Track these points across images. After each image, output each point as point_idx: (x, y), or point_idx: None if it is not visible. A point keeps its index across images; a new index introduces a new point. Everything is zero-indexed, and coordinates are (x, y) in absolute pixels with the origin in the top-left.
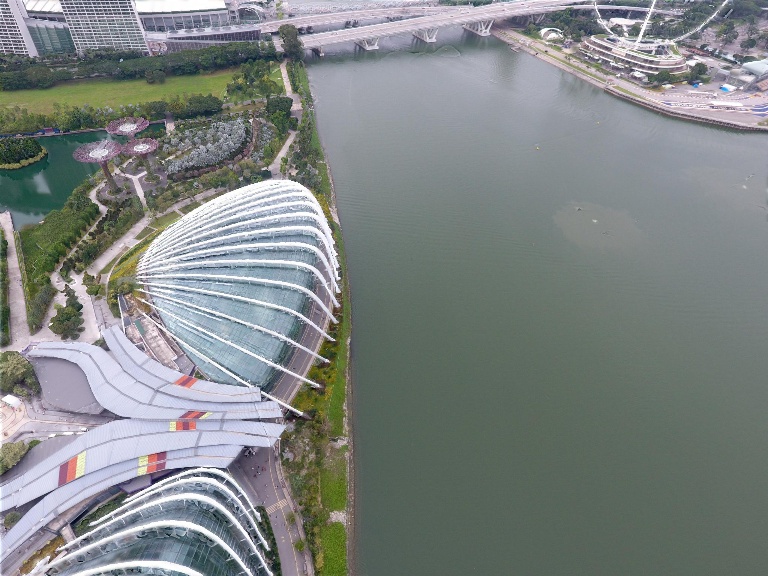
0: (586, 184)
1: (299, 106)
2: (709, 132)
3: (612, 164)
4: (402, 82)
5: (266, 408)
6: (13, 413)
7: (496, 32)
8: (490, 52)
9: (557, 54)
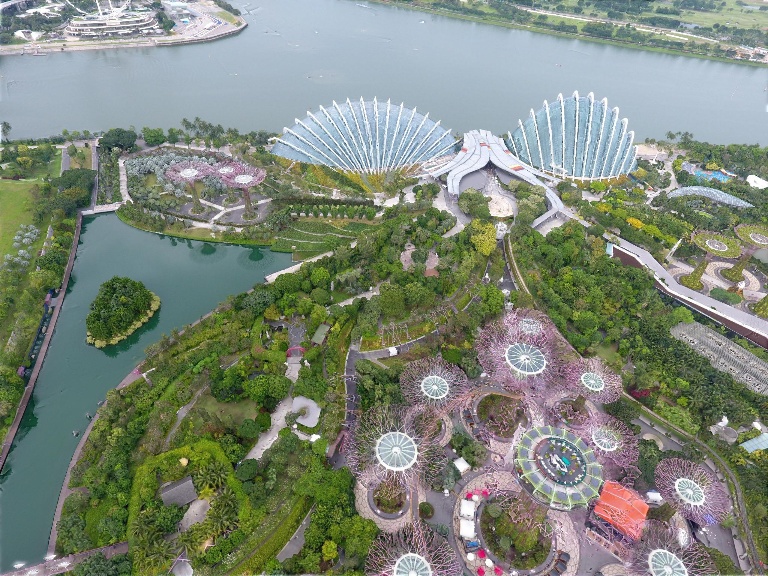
0: (284, 72)
1: None
2: (230, 40)
3: (263, 63)
4: (71, 101)
5: None
6: None
7: None
8: (0, 72)
9: (75, 43)
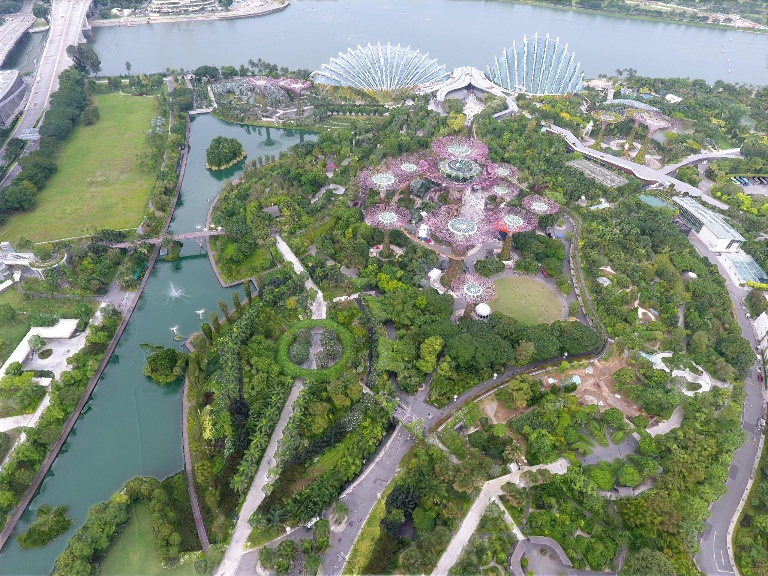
0: None
1: (194, 76)
2: (276, 16)
3: (304, 30)
4: None
5: (462, 68)
6: None
7: (90, 24)
8: None
9: None
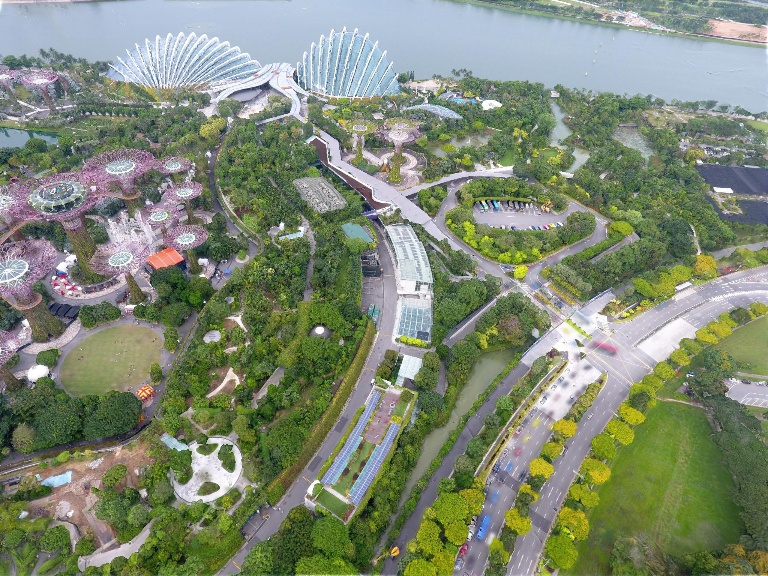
0: (169, 23)
1: None
2: None
3: (157, 16)
4: None
5: (276, 64)
6: (251, 108)
7: None
8: None
9: None
